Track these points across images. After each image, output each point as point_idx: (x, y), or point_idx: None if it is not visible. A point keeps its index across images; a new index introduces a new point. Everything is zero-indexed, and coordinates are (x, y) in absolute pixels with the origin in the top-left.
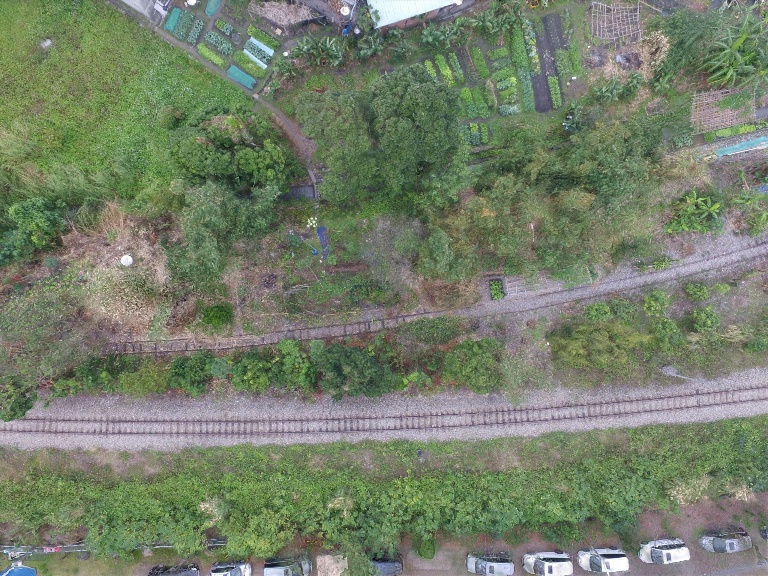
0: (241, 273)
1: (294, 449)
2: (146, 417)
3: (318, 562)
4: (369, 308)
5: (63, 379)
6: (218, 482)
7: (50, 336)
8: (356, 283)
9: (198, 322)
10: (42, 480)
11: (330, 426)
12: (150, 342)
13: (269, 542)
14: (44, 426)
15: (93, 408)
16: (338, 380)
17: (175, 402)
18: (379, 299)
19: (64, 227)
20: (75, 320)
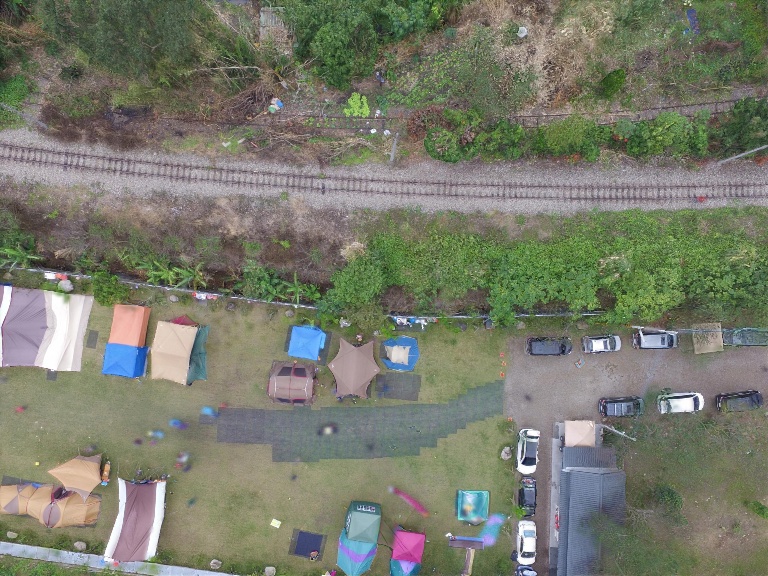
0: (617, 52)
1: (682, 214)
2: (541, 182)
3: (694, 330)
4: (737, 88)
5: (484, 132)
6: (609, 245)
7: (440, 109)
8: (725, 64)
9: (584, 95)
10: (448, 239)
11: (716, 193)
12: (532, 117)
13: (668, 297)
14: (444, 190)
15: (490, 173)
16: (767, 122)
17: (564, 170)
18: (753, 76)
19: (457, 1)
20: (461, 95)
